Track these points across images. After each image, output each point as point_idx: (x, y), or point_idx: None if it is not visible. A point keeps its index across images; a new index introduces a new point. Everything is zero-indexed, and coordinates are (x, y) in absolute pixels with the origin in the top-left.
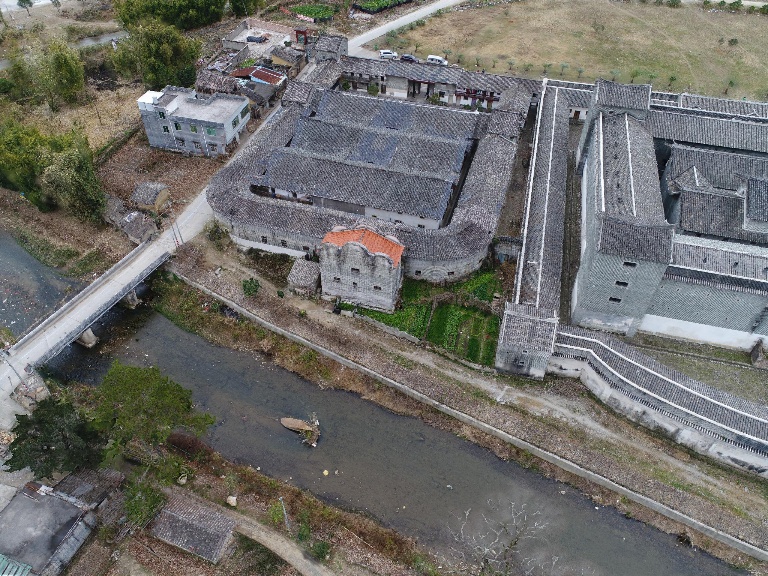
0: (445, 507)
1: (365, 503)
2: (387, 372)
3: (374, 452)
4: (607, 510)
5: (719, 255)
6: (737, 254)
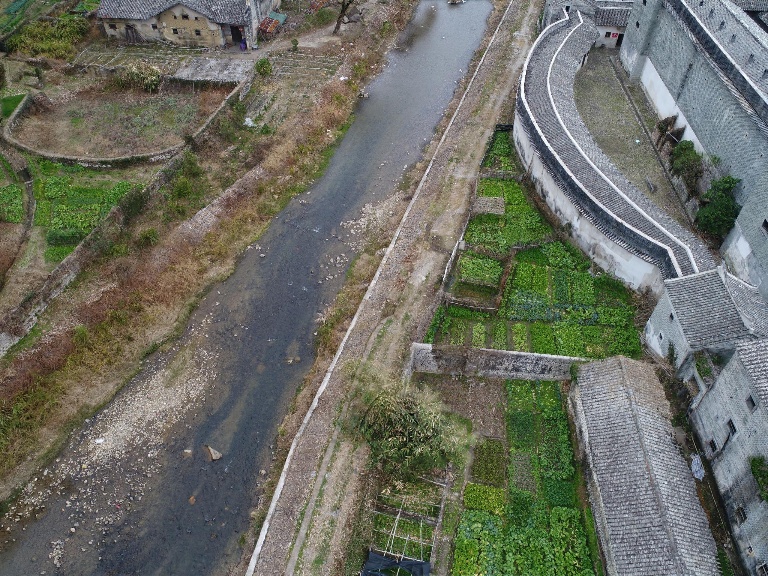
0: (429, 37)
1: (419, 17)
2: (513, 6)
3: (455, 18)
4: (456, 86)
5: (717, 7)
6: (729, 12)
